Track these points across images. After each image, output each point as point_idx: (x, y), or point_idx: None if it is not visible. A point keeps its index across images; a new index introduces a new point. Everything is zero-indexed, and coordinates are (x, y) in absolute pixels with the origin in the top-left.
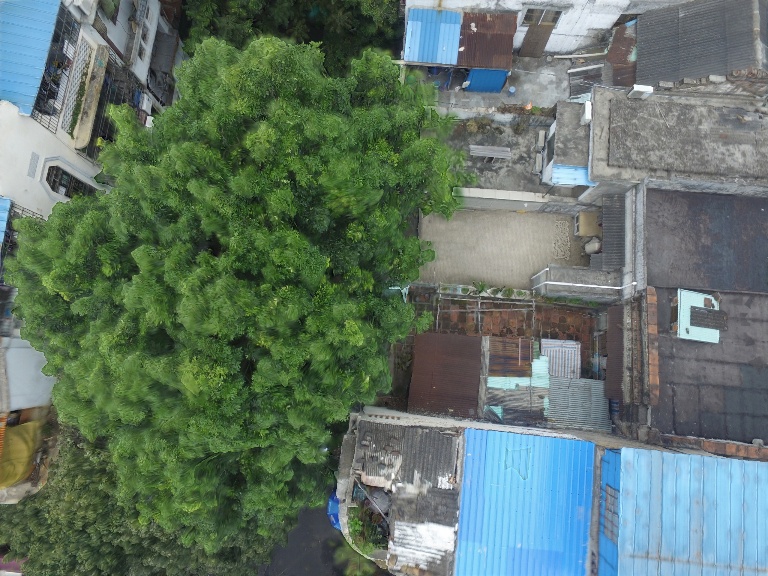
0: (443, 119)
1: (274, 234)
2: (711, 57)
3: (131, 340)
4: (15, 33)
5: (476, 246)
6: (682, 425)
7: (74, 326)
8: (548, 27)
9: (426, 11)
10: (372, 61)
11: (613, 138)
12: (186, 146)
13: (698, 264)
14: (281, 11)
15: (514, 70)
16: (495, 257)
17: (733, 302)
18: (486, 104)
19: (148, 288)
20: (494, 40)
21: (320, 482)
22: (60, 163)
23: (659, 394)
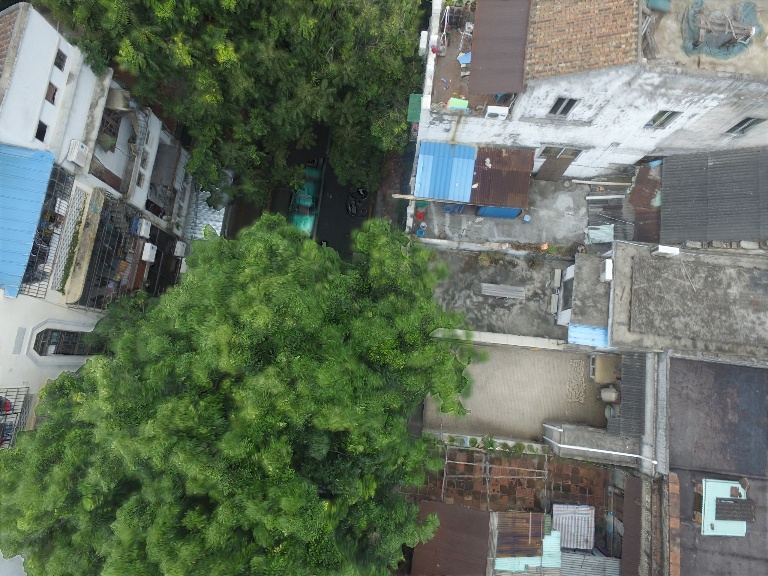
0: (454, 249)
1: (267, 497)
2: (742, 216)
3: None
4: (3, 206)
5: (485, 385)
6: None
7: (55, 533)
8: (567, 160)
9: (438, 144)
10: (380, 236)
11: (635, 301)
12: (173, 407)
13: (724, 444)
14: None
15: (529, 194)
16: (505, 398)
17: (761, 489)
18: (499, 231)
19: (127, 567)
20: (510, 177)
21: None
22: (49, 324)
23: None
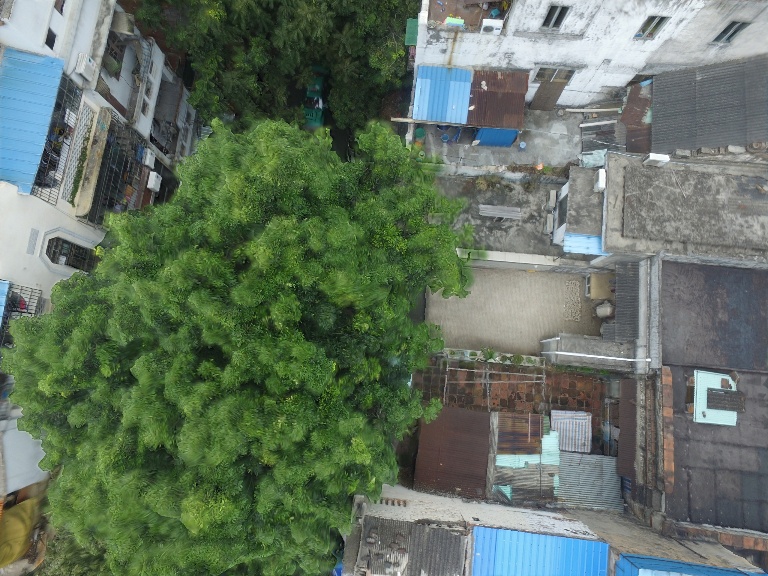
0: (452, 175)
1: (278, 346)
2: (730, 125)
3: (129, 457)
4: (15, 108)
5: (484, 306)
6: (697, 512)
7: None
8: (560, 84)
9: (435, 68)
10: (381, 136)
11: (628, 208)
12: (188, 257)
13: (715, 341)
14: (287, 63)
15: (525, 123)
16: (504, 318)
17: (751, 382)
18: (496, 159)
19: (147, 407)
20: (505, 99)
21: (323, 570)
22: (60, 233)
23: (674, 478)
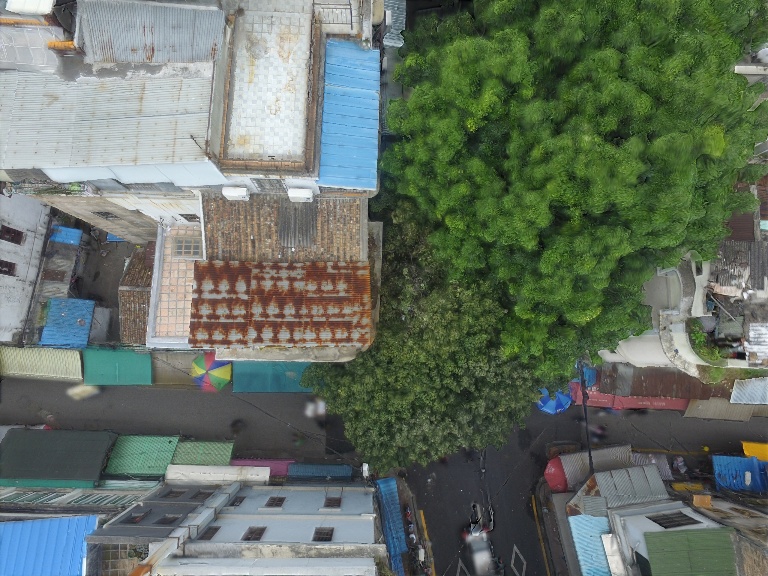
0: None
1: None
2: None
3: None
4: None
5: None
6: None
7: None
8: None
9: None
10: None
11: None
12: None
13: None
14: None
15: None
16: None
17: None
18: None
19: None
20: None
21: None
22: None
23: None
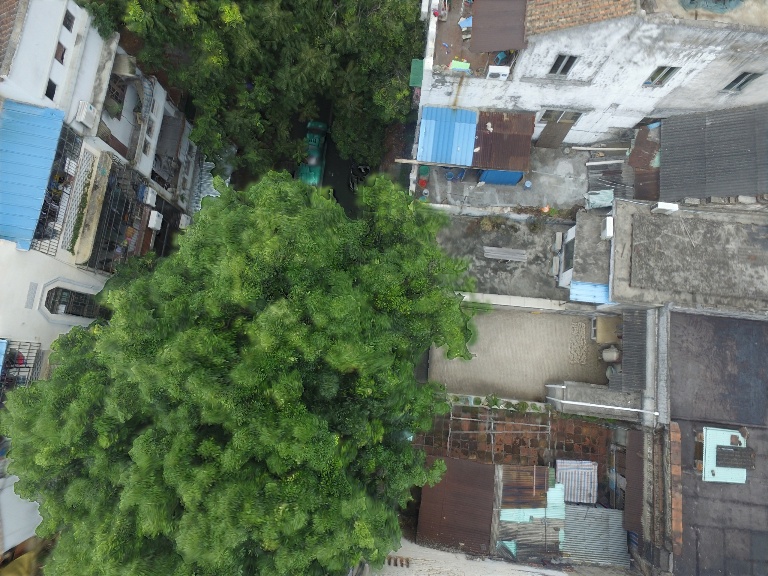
0: (456, 215)
1: (280, 426)
2: (740, 173)
3: (127, 540)
4: (14, 162)
5: (489, 348)
6: (706, 572)
7: (70, 478)
8: (567, 124)
9: (440, 109)
10: (385, 190)
11: (635, 257)
12: (188, 337)
13: (724, 395)
14: (290, 100)
15: (530, 161)
16: (508, 361)
17: (761, 438)
18: (501, 197)
19: (145, 492)
20: (511, 141)
21: None
22: (60, 283)
23: (682, 537)
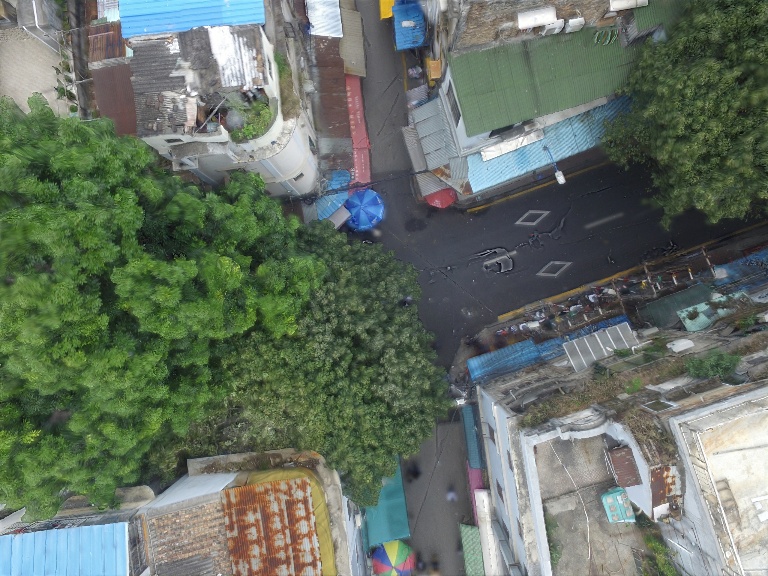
0: None
1: None
2: None
3: None
4: None
5: None
6: None
7: None
8: None
9: None
10: None
11: None
12: None
13: None
14: None
15: None
16: (48, 94)
17: None
18: None
19: None
20: None
21: None
22: None
23: None
